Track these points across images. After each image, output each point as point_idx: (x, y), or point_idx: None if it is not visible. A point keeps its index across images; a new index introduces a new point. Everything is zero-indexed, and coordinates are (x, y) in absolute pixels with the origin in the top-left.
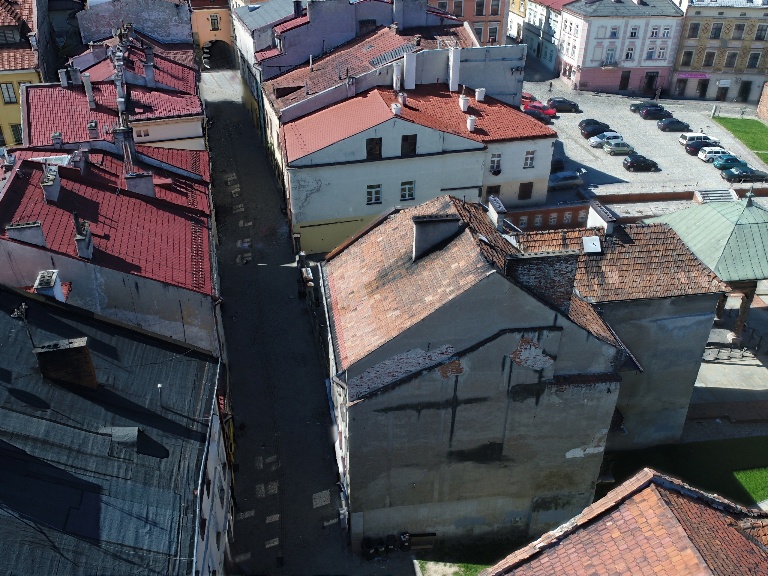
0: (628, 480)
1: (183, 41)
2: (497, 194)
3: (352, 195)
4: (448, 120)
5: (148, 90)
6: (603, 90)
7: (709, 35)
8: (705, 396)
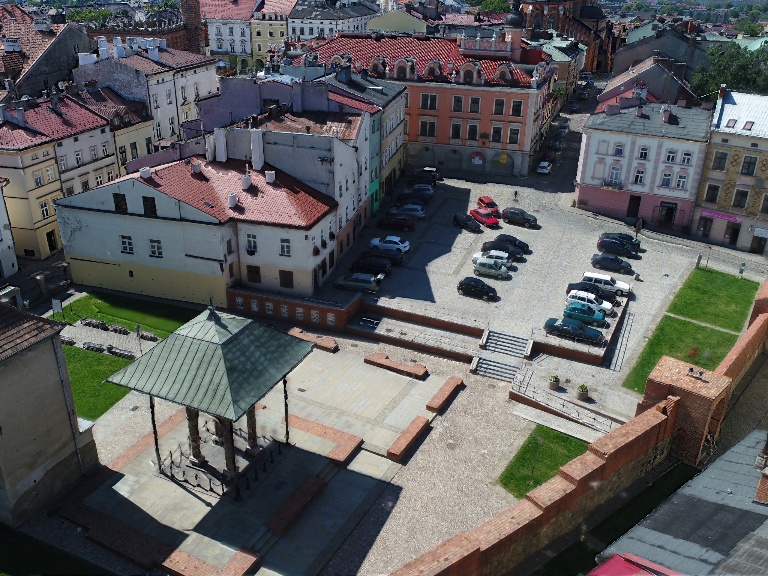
0: None
1: (142, 100)
2: (258, 275)
3: (108, 240)
4: (223, 194)
5: (17, 128)
6: (607, 213)
7: (739, 169)
8: (107, 504)
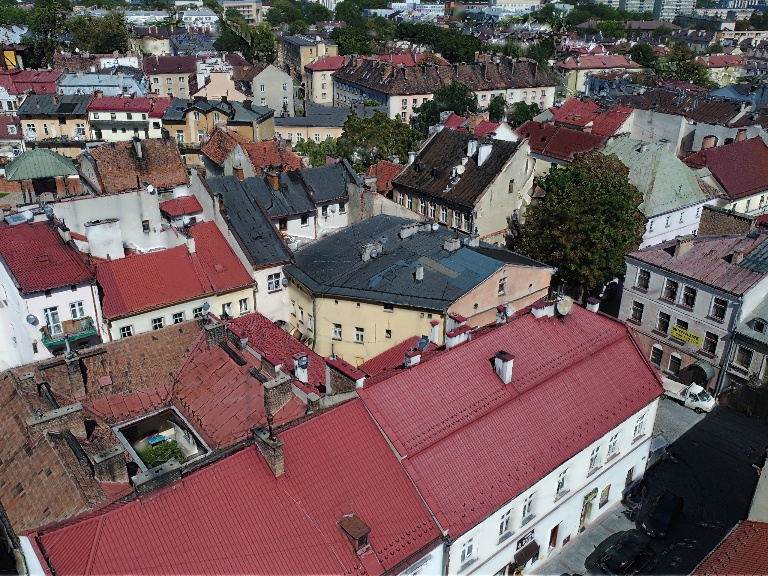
0: (241, 146)
1: None
2: None
3: None
4: None
5: None
6: None
7: None
8: None
